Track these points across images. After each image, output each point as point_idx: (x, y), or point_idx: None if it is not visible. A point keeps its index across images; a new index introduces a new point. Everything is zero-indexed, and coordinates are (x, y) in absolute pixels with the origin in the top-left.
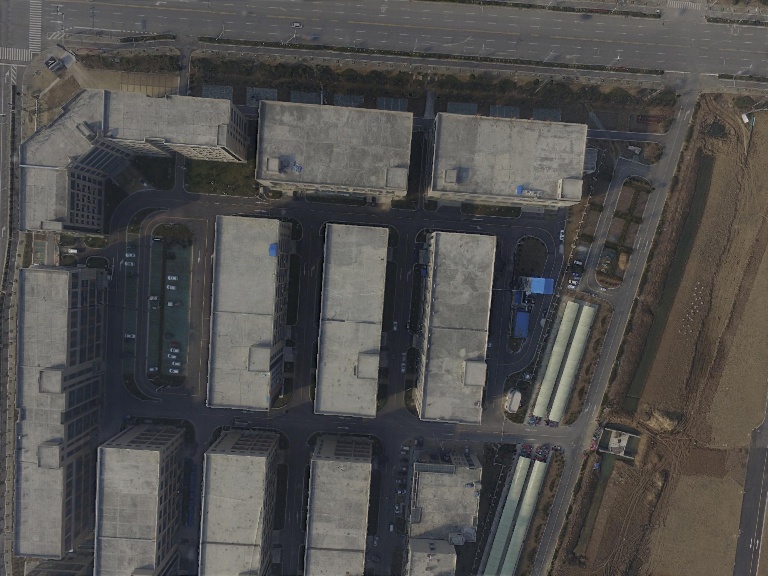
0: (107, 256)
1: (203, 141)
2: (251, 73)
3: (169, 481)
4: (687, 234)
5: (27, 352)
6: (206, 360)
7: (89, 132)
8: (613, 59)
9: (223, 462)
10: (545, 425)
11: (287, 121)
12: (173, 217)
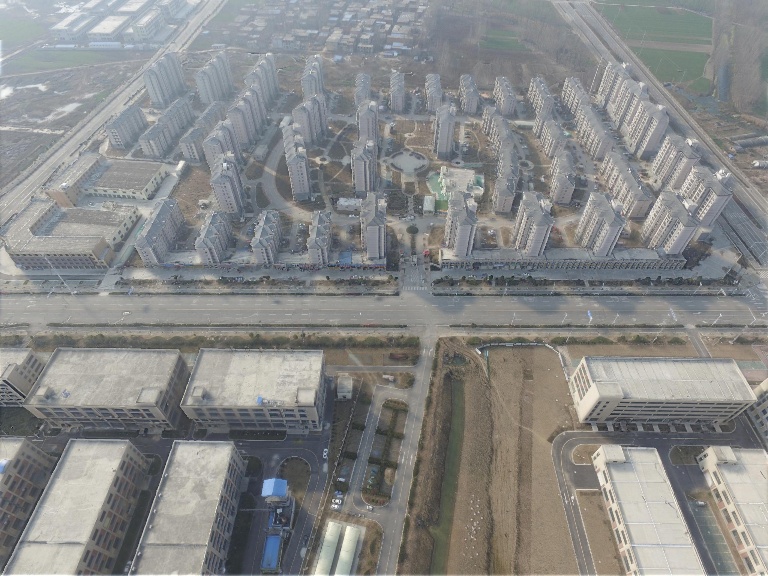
0: None
1: None
2: (77, 343)
3: None
4: (453, 448)
5: None
6: None
7: None
8: (366, 320)
9: None
10: None
11: (73, 361)
12: None
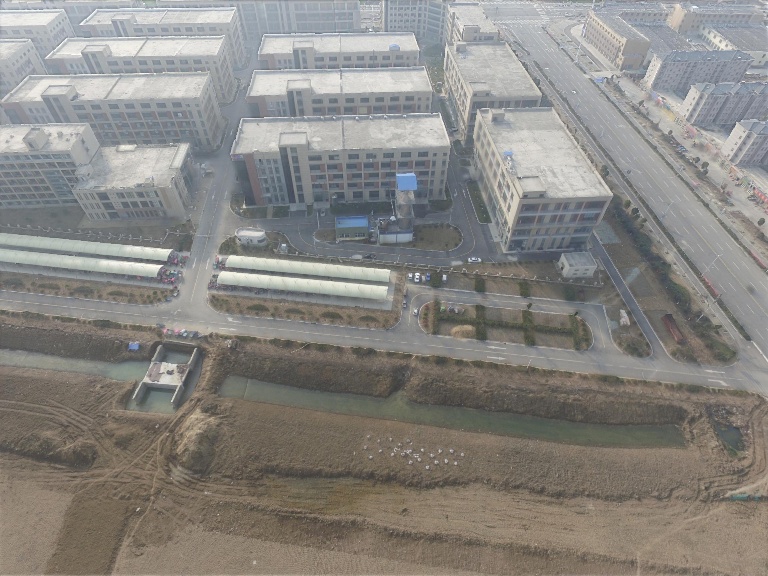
0: None
1: None
2: None
3: None
4: (540, 427)
5: None
6: None
7: None
8: (717, 283)
9: (216, 43)
10: None
11: (498, 52)
12: None
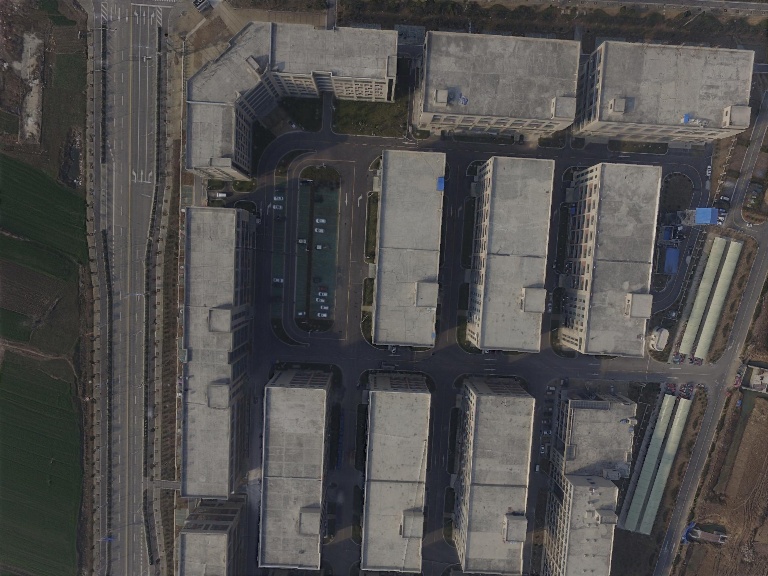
0: (255, 200)
1: (369, 74)
2: (399, 10)
3: (326, 422)
4: None
5: (193, 292)
6: (353, 304)
7: (258, 65)
8: None
9: (388, 400)
10: (689, 363)
11: (453, 52)
12: (320, 159)
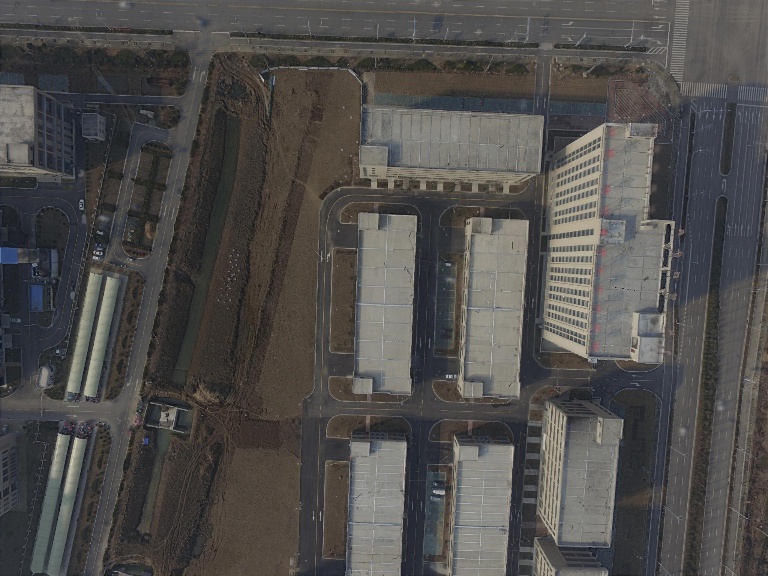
0: None
1: None
2: None
3: None
4: (221, 200)
5: None
6: None
7: None
8: (118, 20)
9: None
10: (86, 401)
11: None
12: None
